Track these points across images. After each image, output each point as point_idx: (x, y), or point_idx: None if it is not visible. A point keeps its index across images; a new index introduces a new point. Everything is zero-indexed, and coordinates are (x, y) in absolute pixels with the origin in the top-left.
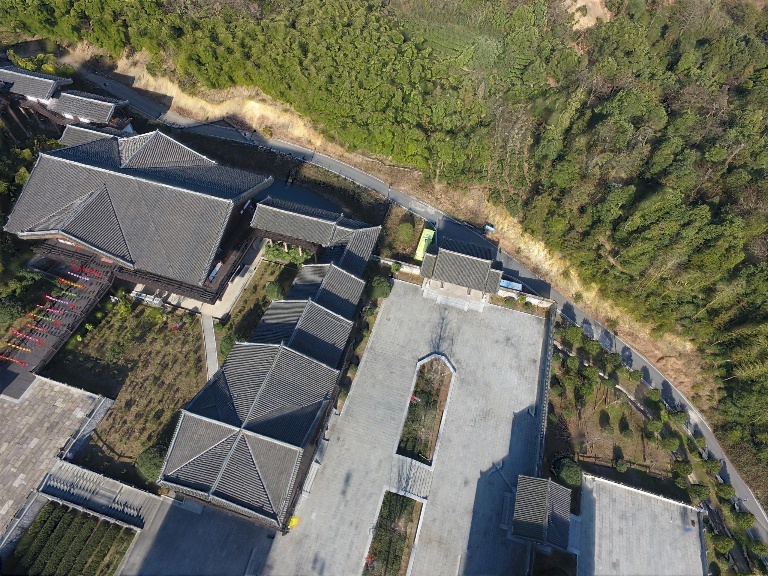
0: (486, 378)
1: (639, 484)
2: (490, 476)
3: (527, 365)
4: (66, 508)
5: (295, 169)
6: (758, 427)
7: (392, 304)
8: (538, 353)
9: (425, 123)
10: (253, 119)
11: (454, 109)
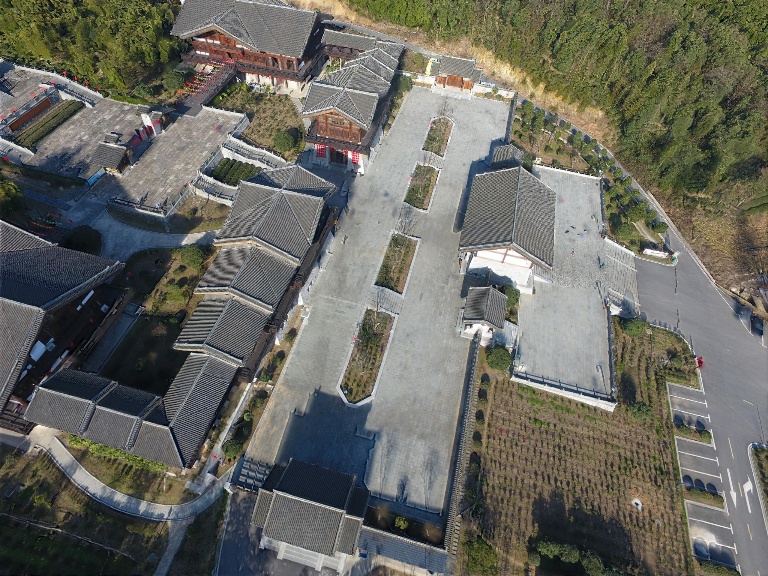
0: (474, 126)
1: None
2: (478, 162)
3: (499, 122)
4: (235, 161)
5: None
6: (640, 148)
7: (412, 95)
8: (506, 117)
9: (428, 1)
10: (305, 5)
11: None
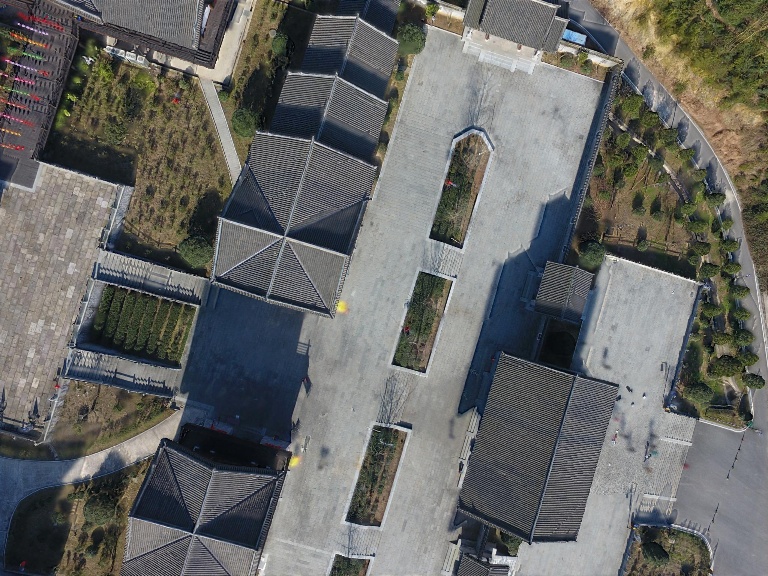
0: (526, 157)
1: (654, 261)
2: (517, 257)
3: (572, 142)
4: (125, 290)
5: None
6: None
7: (425, 63)
8: (587, 127)
9: None
10: None
11: None
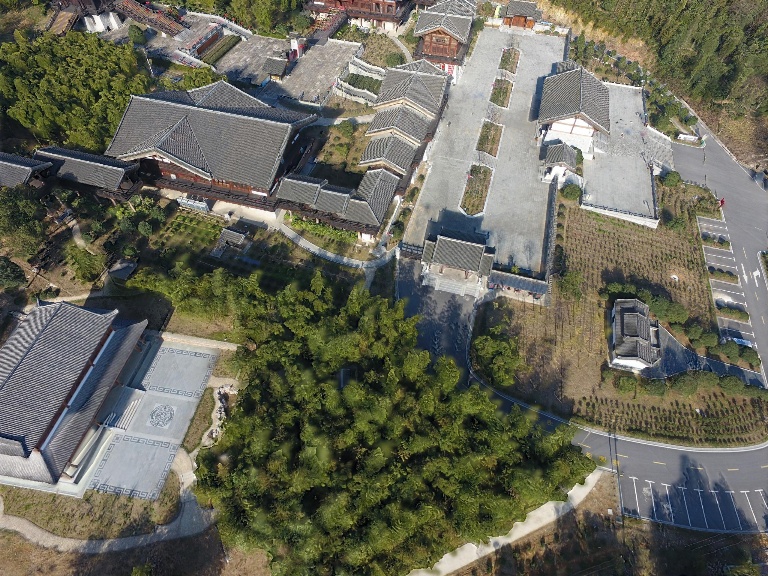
0: (537, 54)
1: None
2: (543, 78)
3: (558, 51)
4: (359, 75)
5: None
6: (674, 67)
7: (485, 34)
8: (563, 47)
9: None
10: None
11: None
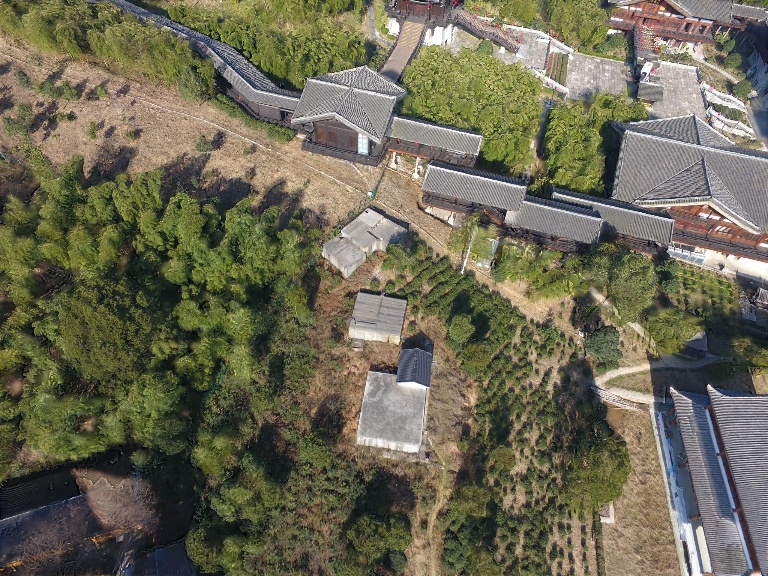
0: None
1: None
2: None
3: None
4: None
5: None
6: None
7: None
8: None
9: None
10: None
11: None
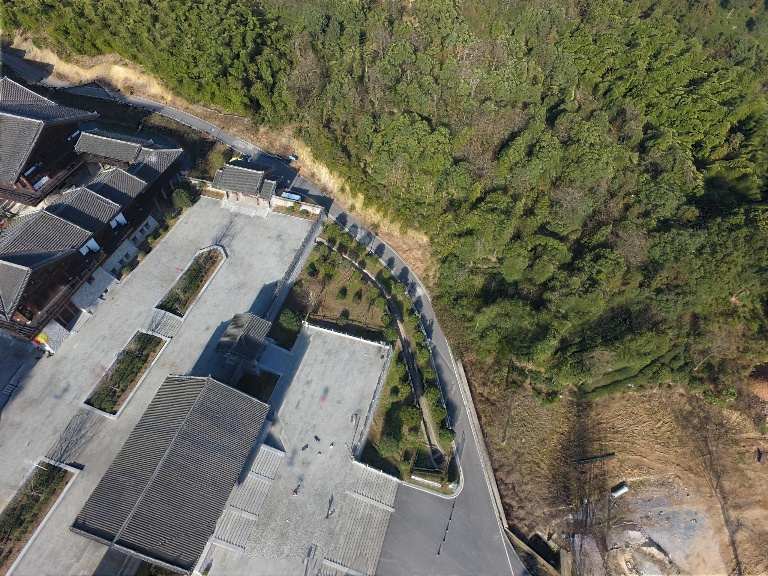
0: (251, 262)
1: (354, 334)
2: (228, 324)
3: (288, 253)
4: None
5: (144, 118)
6: (461, 294)
7: (193, 212)
8: None
9: (252, 78)
10: (118, 81)
11: (279, 67)
